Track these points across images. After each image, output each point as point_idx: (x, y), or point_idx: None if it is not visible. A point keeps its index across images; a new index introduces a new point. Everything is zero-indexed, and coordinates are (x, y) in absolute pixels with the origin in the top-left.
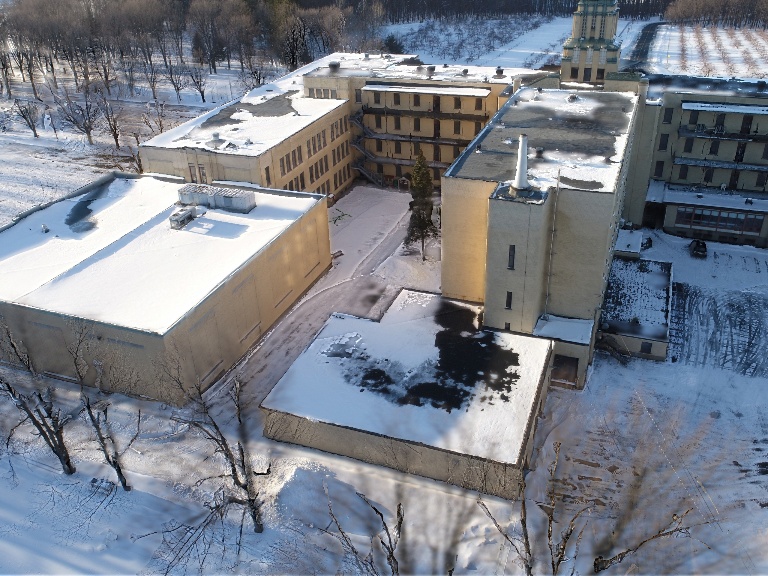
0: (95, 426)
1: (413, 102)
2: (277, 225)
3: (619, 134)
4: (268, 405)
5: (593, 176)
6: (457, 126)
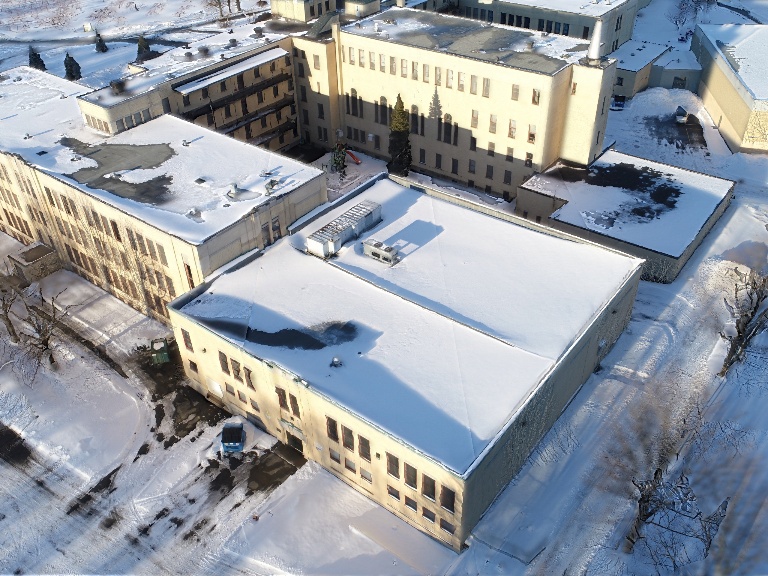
0: (761, 299)
1: (220, 88)
2: (429, 204)
3: (490, 25)
4: (678, 254)
5: (569, 43)
6: (260, 95)
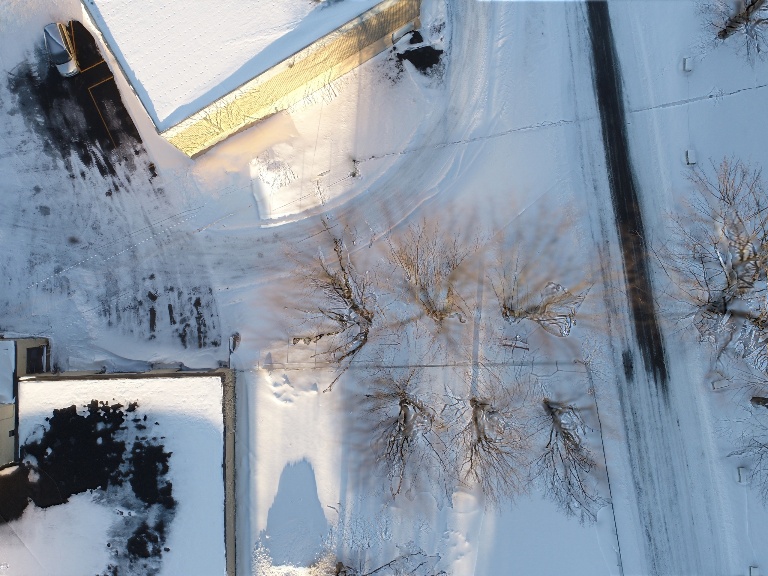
0: None
1: None
2: None
3: None
4: None
5: None
6: None
